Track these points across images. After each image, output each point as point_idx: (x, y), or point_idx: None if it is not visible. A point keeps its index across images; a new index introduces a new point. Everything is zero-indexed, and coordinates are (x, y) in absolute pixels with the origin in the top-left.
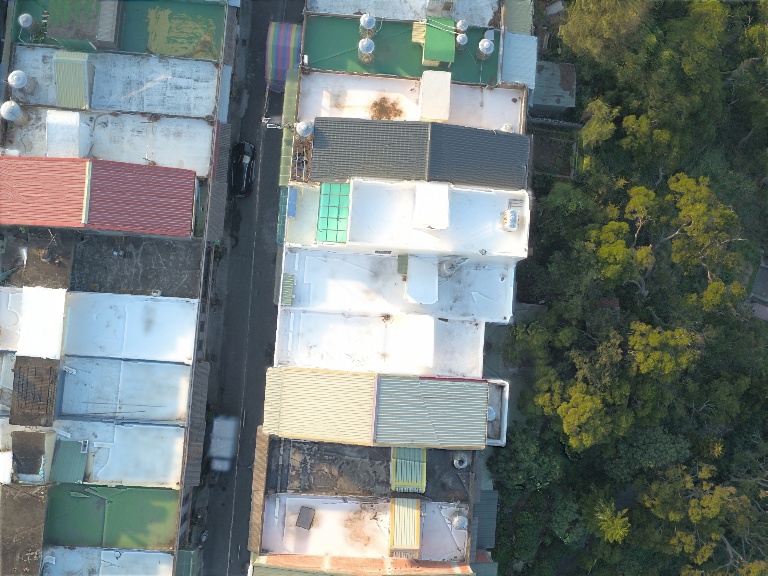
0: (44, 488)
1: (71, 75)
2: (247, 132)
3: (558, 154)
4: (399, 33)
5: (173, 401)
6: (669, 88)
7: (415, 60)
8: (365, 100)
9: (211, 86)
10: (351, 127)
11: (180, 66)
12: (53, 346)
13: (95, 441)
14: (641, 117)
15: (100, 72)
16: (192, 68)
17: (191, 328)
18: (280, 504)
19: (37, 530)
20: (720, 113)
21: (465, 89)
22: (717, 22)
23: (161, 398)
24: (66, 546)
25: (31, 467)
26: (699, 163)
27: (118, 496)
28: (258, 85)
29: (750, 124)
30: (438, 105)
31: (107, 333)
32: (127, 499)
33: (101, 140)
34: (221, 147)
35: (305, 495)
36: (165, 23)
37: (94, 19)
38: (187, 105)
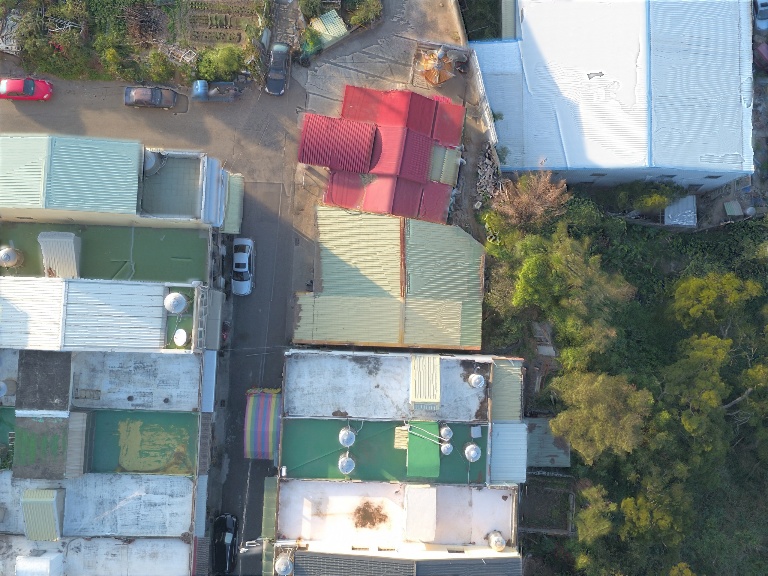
0: None
1: (40, 513)
2: (229, 499)
3: (554, 505)
4: (381, 431)
5: None
6: (669, 454)
7: (399, 459)
8: (348, 505)
9: (187, 501)
10: (333, 563)
11: (154, 481)
12: None
13: None
14: (640, 502)
15: (71, 493)
16: (166, 482)
17: None
18: None
19: None
20: (724, 459)
21: (452, 489)
22: (718, 360)
23: None
24: None
25: None
26: (703, 509)
27: None
28: (239, 448)
29: (756, 458)
30: (424, 525)
31: None
32: None
33: (74, 566)
34: (199, 563)
35: None
36: (136, 436)
37: (61, 456)
38: (162, 523)
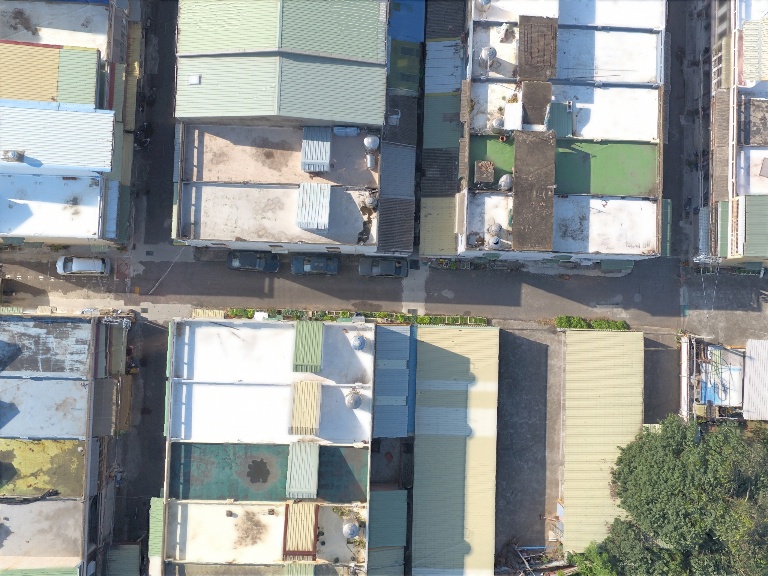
0: (553, 132)
1: None
2: None
3: None
4: None
5: (643, 66)
6: None
7: None
8: None
9: None
10: None
11: None
12: (552, 6)
13: (577, 102)
14: None
15: None
16: None
17: (655, 0)
18: (745, 156)
19: (549, 169)
20: None
21: None
22: None
23: (632, 64)
24: (562, 193)
25: (536, 117)
26: None
27: (601, 151)
28: None
29: None
30: None
31: (580, 6)
32: (609, 154)
33: None
34: None
35: (767, 147)
36: None
37: None
38: None
